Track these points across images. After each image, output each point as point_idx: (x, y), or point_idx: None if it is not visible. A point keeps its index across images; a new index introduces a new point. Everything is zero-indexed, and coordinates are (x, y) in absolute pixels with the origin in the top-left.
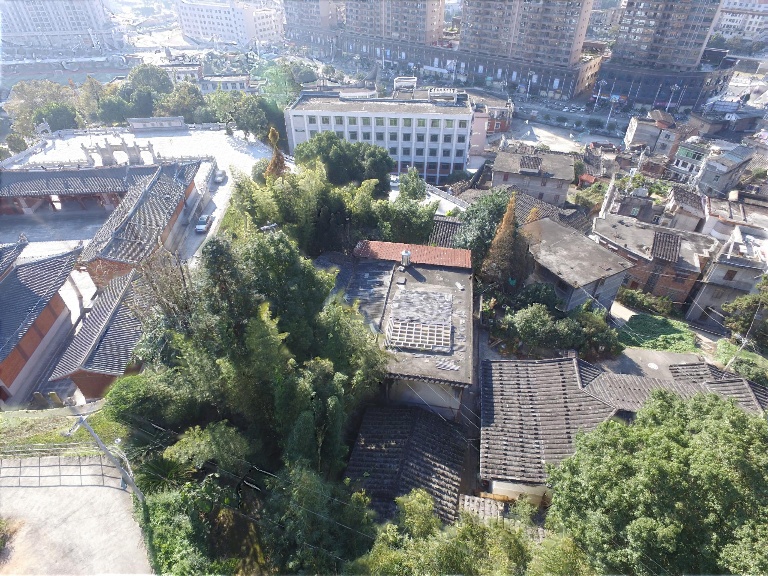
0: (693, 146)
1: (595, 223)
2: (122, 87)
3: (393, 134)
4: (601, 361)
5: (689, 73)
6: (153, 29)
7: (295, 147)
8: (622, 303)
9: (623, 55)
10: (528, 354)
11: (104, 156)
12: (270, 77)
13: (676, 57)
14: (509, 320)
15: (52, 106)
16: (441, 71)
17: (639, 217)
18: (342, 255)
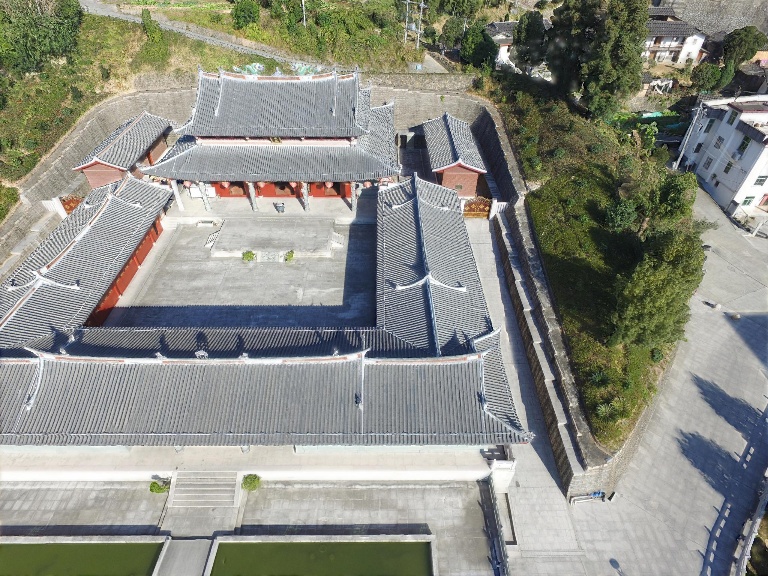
0: None
1: None
2: None
3: None
4: None
5: None
6: None
7: None
8: None
9: None
10: None
11: None
12: None
13: None
14: None
15: None
16: None
17: None
18: None
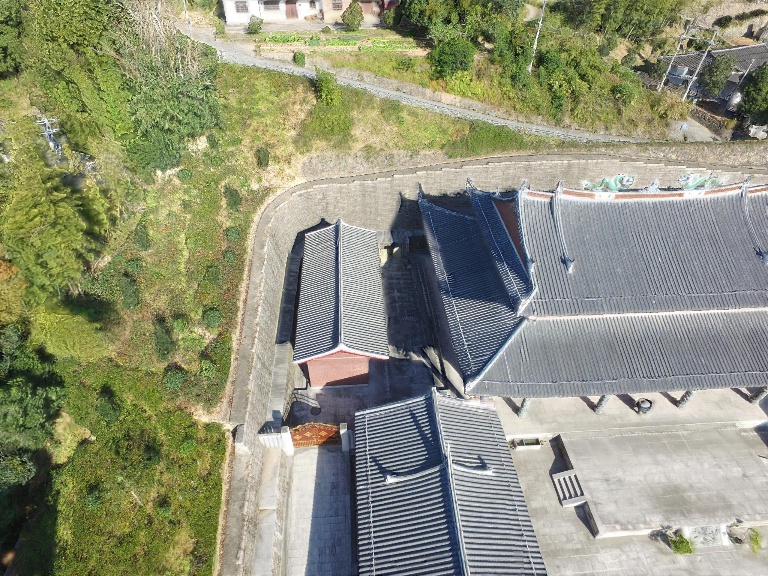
0: None
1: None
2: None
3: None
4: None
5: None
6: None
7: None
8: None
9: None
10: None
11: None
12: None
13: None
14: None
15: None
16: None
17: None
18: None
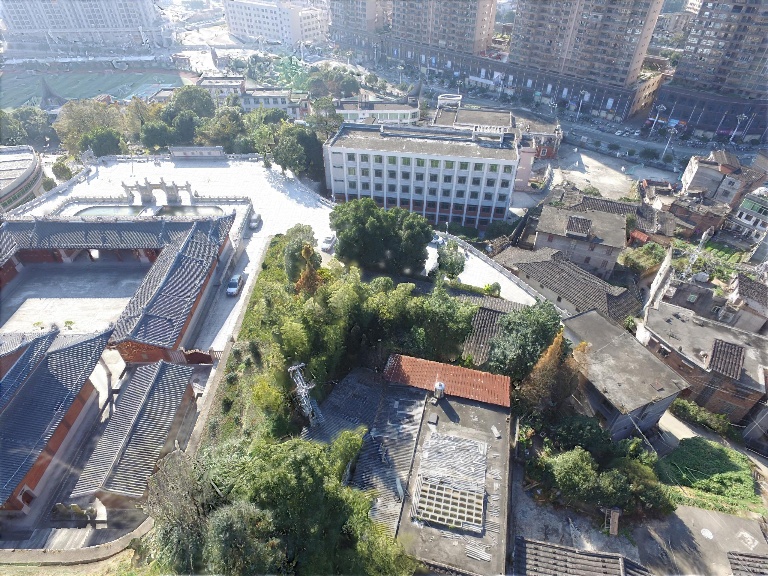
0: (760, 200)
1: (647, 315)
2: (165, 109)
3: (433, 175)
4: (648, 521)
5: (759, 101)
6: (201, 24)
7: (332, 182)
8: (672, 412)
9: (686, 76)
10: (566, 505)
11: (143, 194)
12: (312, 85)
13: (746, 82)
14: (547, 462)
15: (97, 131)
16: (487, 82)
17: (696, 304)
18: (372, 373)
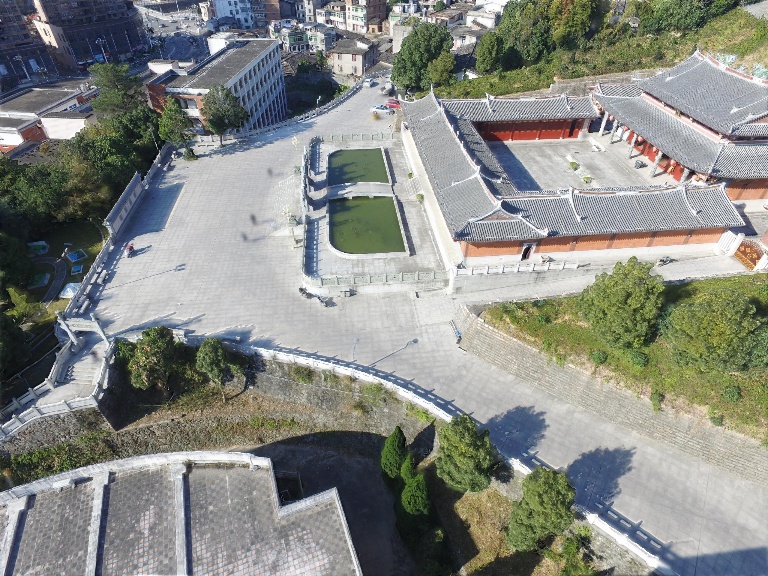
0: (295, 33)
1: None
2: None
3: (260, 80)
4: None
5: (132, 16)
6: None
7: None
8: None
9: (61, 17)
10: None
11: None
12: None
13: (107, 6)
14: None
15: None
16: None
17: None
18: None
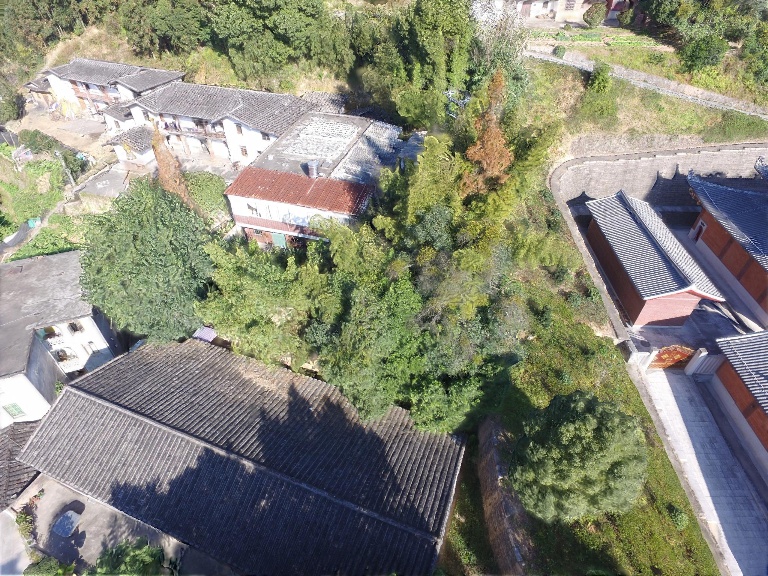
0: None
1: None
2: None
3: None
4: None
5: None
6: None
7: None
8: None
9: None
10: None
11: None
12: None
13: None
14: (224, 197)
15: None
16: None
17: None
18: None
